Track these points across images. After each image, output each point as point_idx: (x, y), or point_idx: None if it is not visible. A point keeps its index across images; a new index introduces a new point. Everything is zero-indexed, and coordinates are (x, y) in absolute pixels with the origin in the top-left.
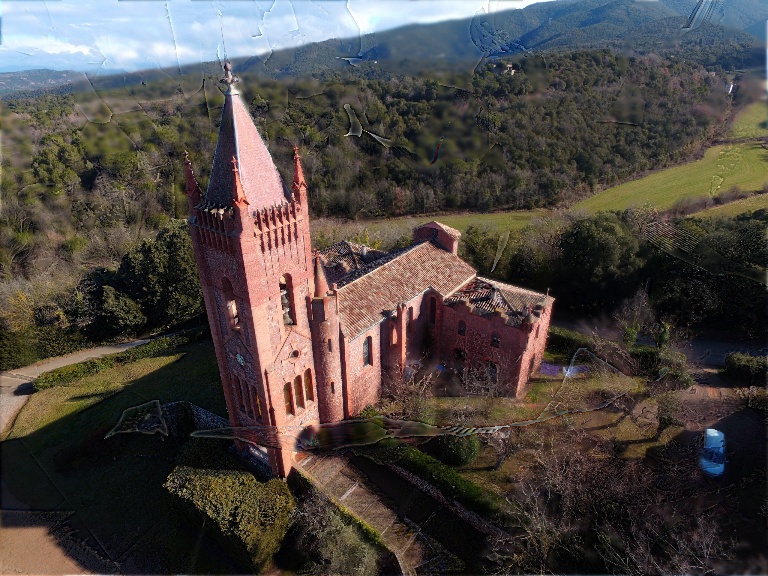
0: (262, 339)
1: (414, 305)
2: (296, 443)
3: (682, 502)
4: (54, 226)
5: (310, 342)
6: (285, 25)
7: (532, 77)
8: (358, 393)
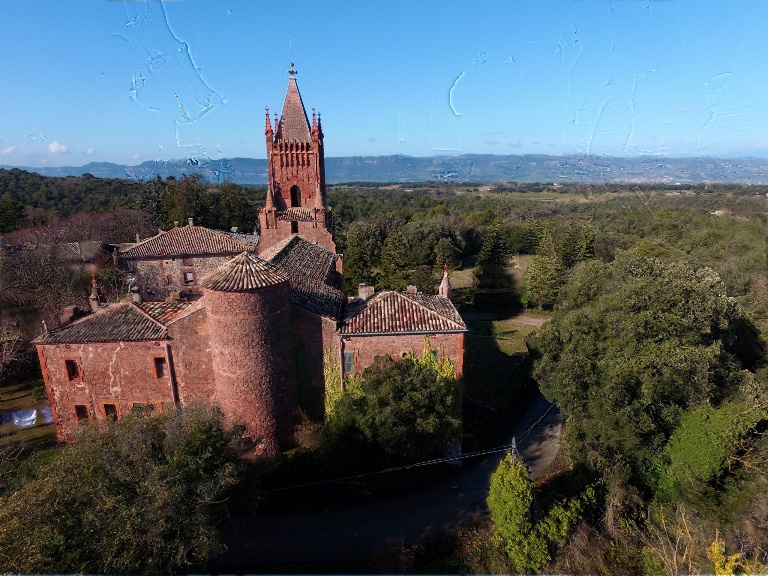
0: None
1: None
2: (188, 164)
3: (69, 219)
4: None
5: None
6: None
7: (106, 55)
8: None
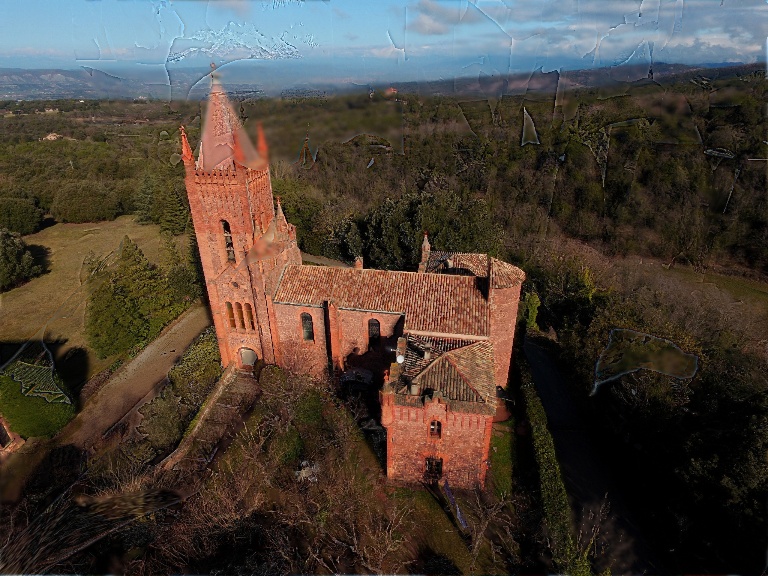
0: (205, 257)
1: (382, 320)
2: None
3: None
4: (382, 177)
5: (250, 284)
6: (680, 10)
7: None
8: (296, 356)
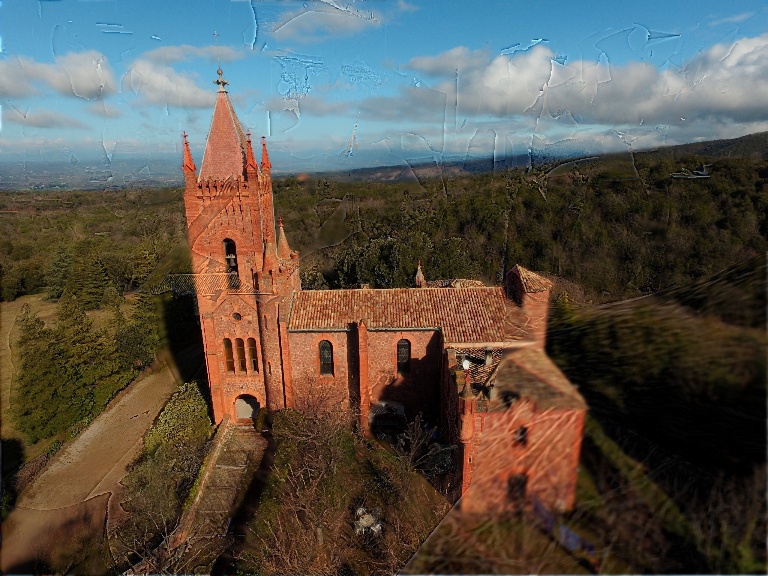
0: None
1: (413, 340)
2: None
3: None
4: None
5: (256, 313)
6: None
7: None
8: (311, 396)
